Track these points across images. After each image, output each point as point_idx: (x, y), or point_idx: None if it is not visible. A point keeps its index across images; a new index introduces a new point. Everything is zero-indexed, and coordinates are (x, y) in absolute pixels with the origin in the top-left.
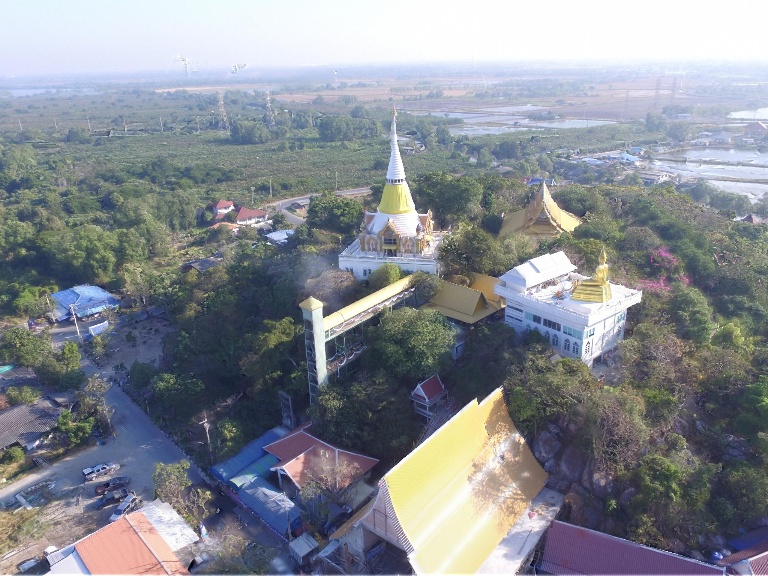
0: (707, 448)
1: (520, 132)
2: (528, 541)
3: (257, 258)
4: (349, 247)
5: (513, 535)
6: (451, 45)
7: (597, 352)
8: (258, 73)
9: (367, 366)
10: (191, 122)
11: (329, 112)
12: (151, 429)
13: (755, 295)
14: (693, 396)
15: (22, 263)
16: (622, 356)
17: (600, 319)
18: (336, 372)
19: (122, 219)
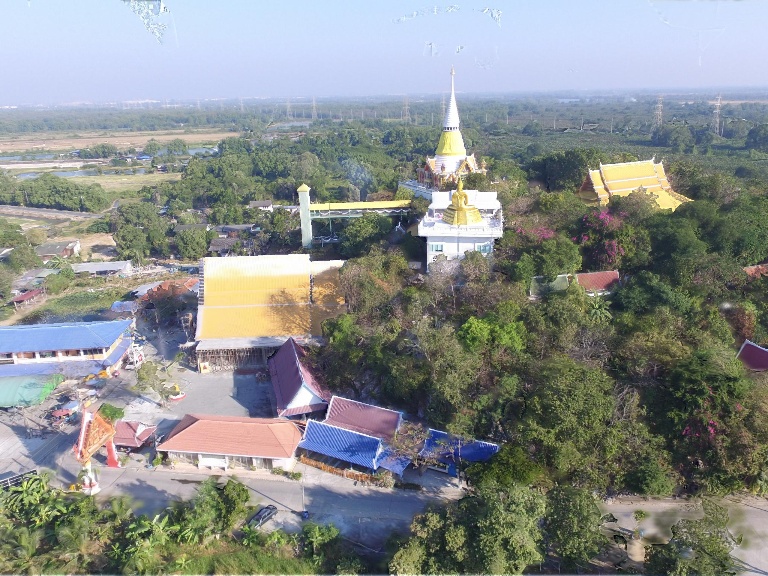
0: None
1: None
2: (274, 343)
3: None
4: None
5: (274, 338)
6: None
7: None
8: (469, 52)
9: None
10: (638, 125)
11: None
12: None
13: (679, 279)
14: None
15: None
16: None
17: (436, 234)
18: (321, 244)
19: None
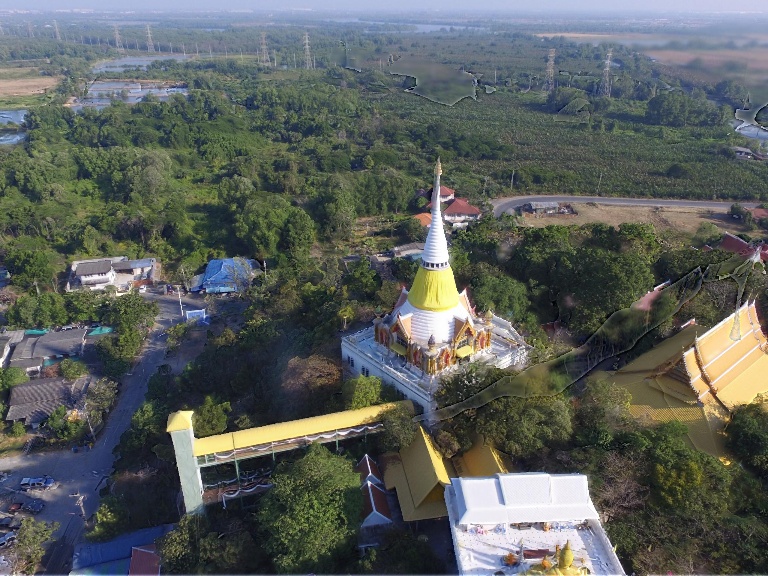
0: None
1: None
2: None
3: (365, 283)
4: (374, 326)
5: None
6: (719, 43)
7: None
8: (409, 69)
9: None
10: (523, 79)
11: (687, 83)
12: None
13: None
14: None
15: None
16: None
17: None
18: (220, 502)
19: (322, 193)
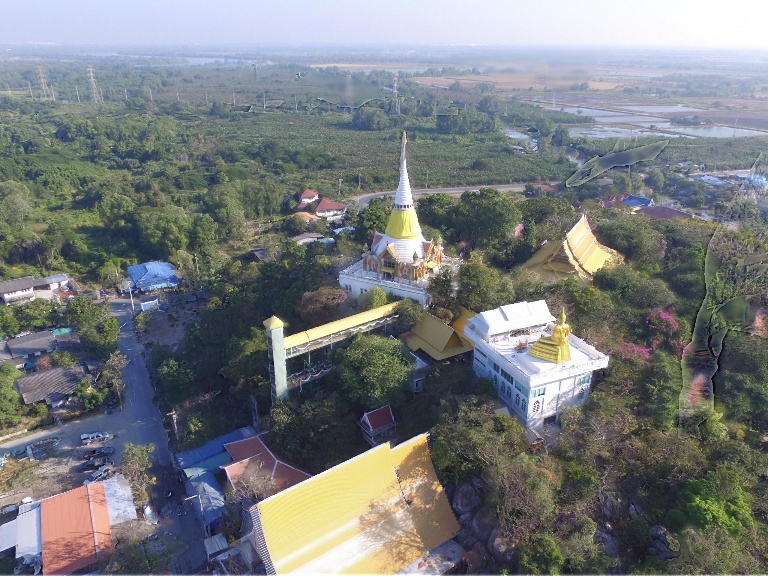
0: (626, 537)
1: (648, 138)
2: None
3: (299, 257)
4: (356, 264)
5: None
6: (525, 59)
7: (550, 412)
8: (317, 82)
9: (330, 385)
10: (322, 103)
11: (457, 101)
12: (152, 407)
13: (763, 376)
14: (642, 477)
15: (120, 233)
16: (562, 423)
17: (547, 381)
18: (298, 387)
19: (208, 202)
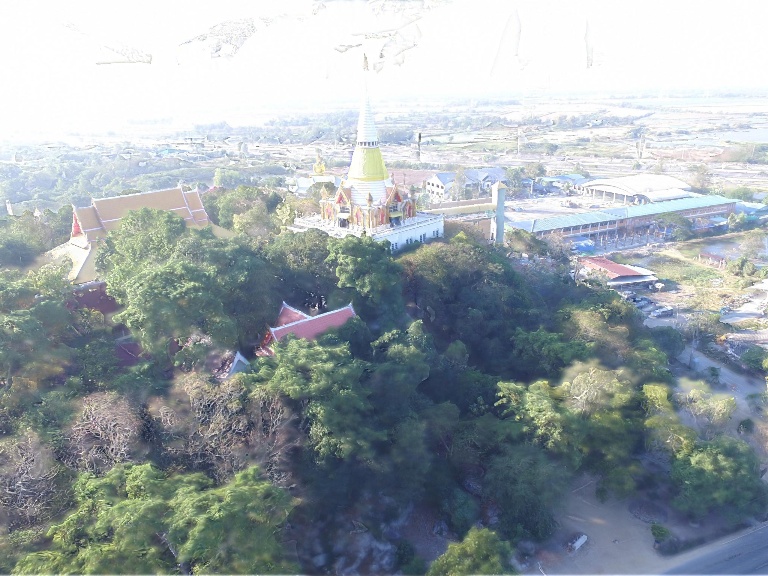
0: None
1: None
2: None
3: None
4: (423, 222)
5: None
6: None
7: None
8: None
9: None
10: None
11: None
12: None
13: None
14: None
15: None
16: None
17: None
18: None
19: None
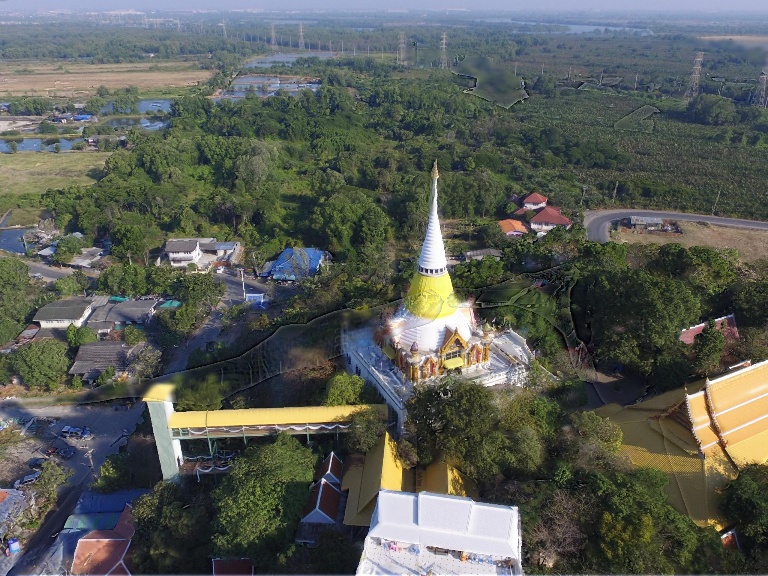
0: None
1: None
2: None
3: None
4: None
5: None
6: None
7: None
8: (471, 69)
9: None
10: (667, 84)
11: None
12: None
13: None
14: None
15: None
16: None
17: None
18: (195, 475)
19: (405, 192)
